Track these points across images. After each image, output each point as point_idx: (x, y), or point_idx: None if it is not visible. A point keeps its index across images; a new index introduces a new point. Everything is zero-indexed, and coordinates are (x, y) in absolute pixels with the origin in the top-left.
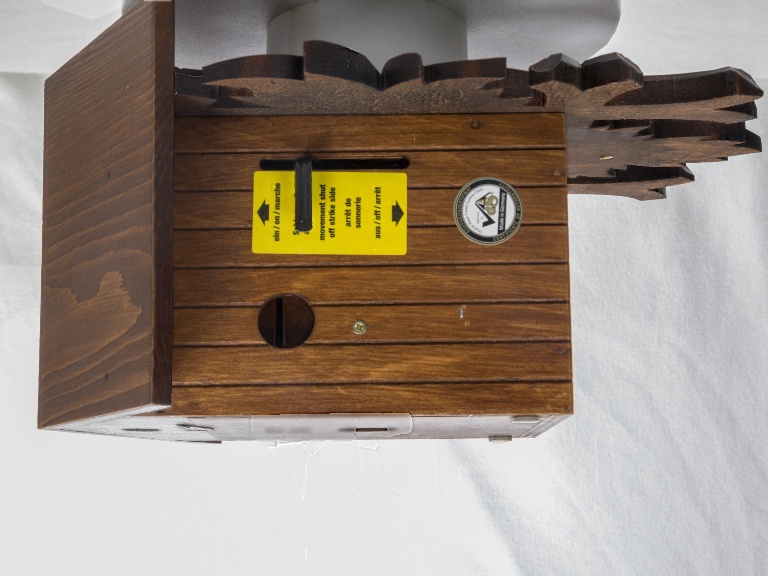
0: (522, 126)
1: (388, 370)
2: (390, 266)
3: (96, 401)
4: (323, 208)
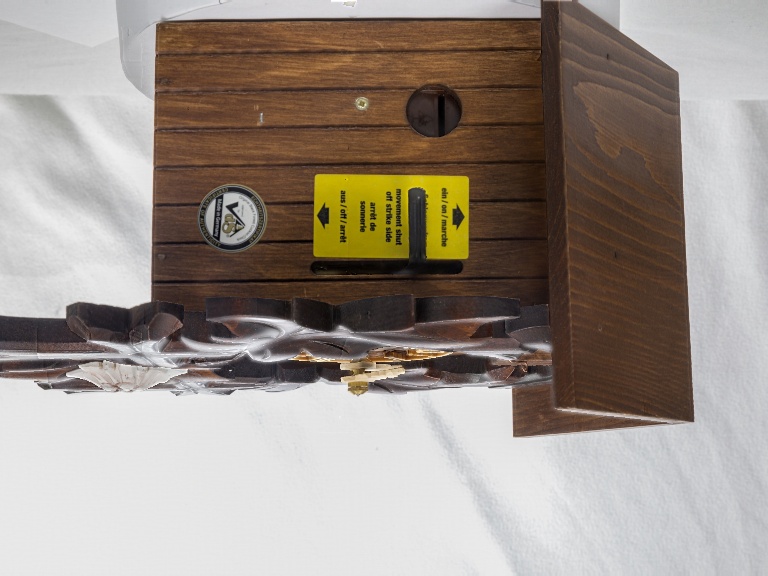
0: (195, 305)
1: (334, 63)
2: (331, 164)
3: (618, 43)
4: (398, 221)
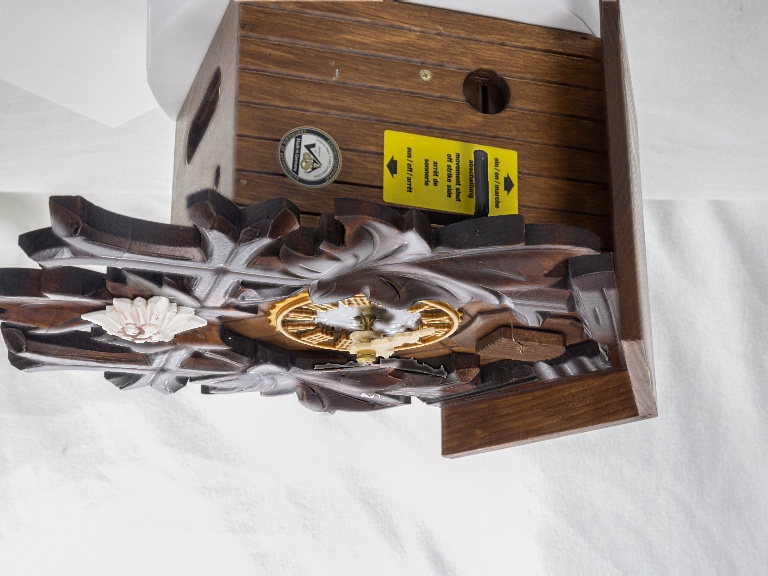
0: None
1: (401, 38)
2: (399, 123)
3: None
4: (458, 181)
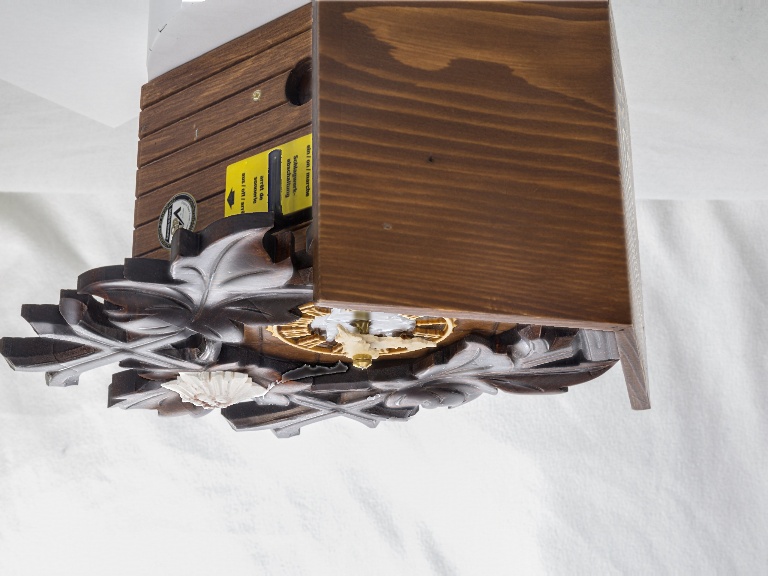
0: None
1: (241, 70)
2: (237, 153)
3: None
4: None
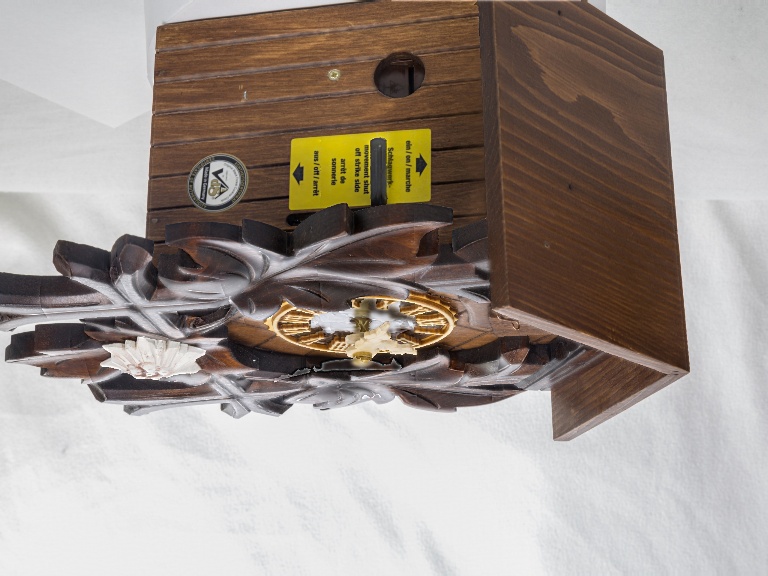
0: None
1: (310, 43)
2: (306, 129)
3: (574, 5)
4: (366, 173)
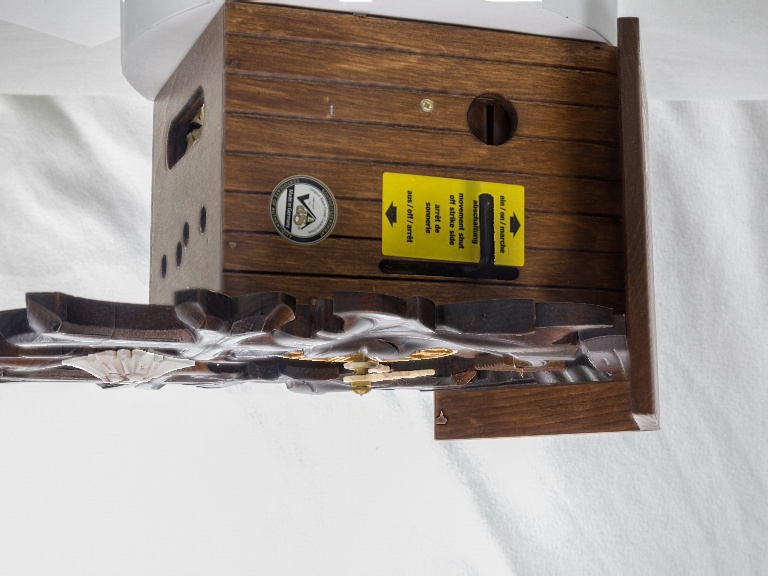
0: None
1: (401, 63)
2: (398, 163)
3: None
4: (461, 225)
